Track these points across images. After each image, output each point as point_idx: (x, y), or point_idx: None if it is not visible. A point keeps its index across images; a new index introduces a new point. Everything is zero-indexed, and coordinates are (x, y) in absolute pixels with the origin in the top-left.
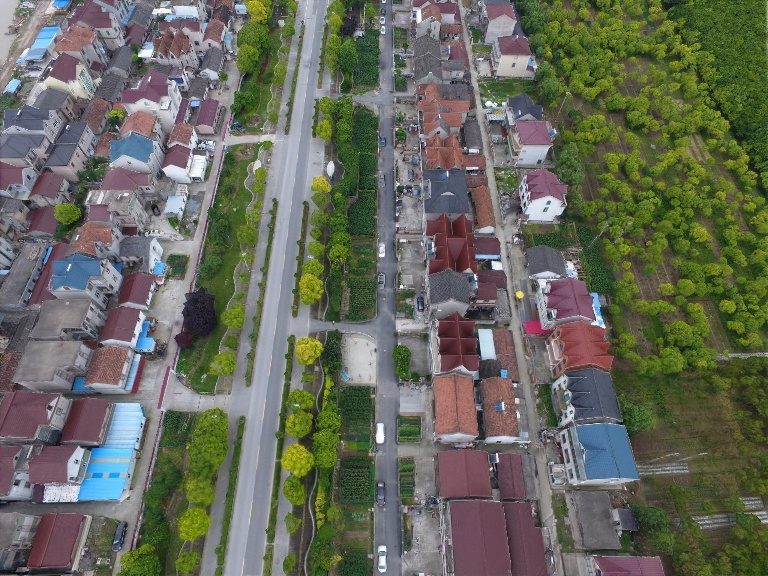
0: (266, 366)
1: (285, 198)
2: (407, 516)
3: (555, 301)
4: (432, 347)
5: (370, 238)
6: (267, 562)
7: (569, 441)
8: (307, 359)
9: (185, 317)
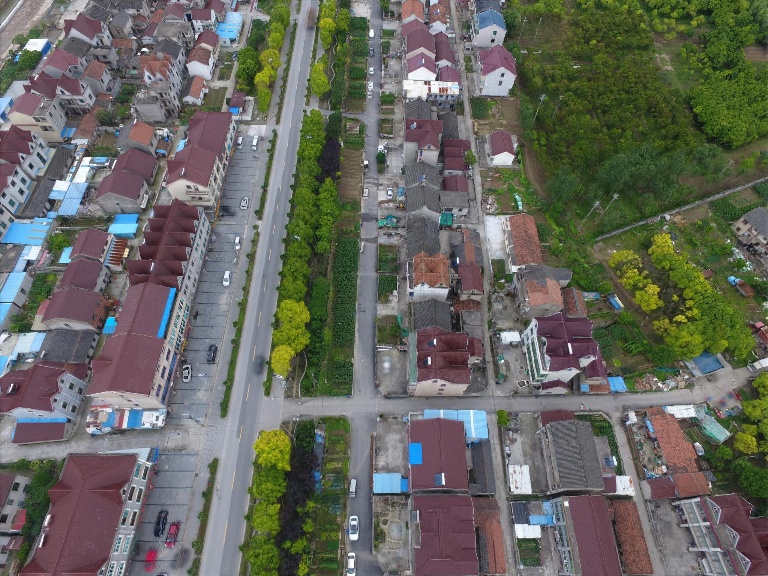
0: (307, 8)
1: None
2: (385, 59)
3: None
4: None
5: None
6: None
7: None
8: None
9: None
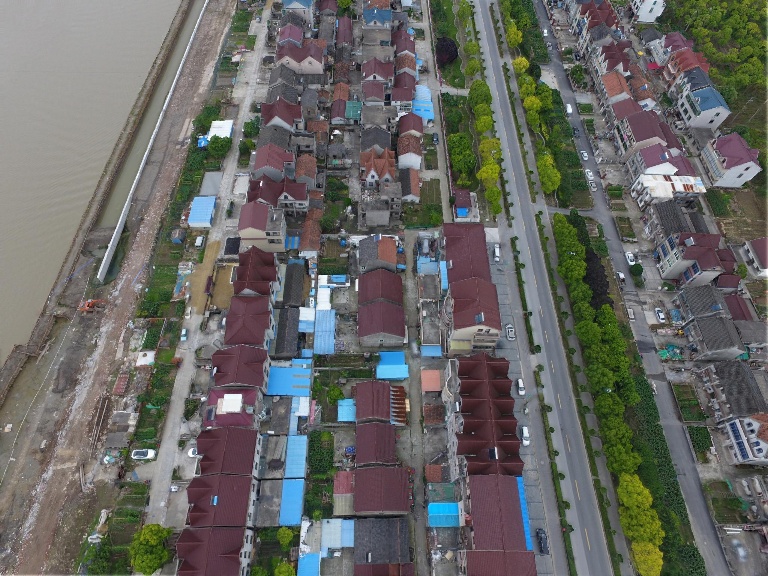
0: (492, 78)
1: (475, 4)
2: (593, 141)
3: (669, 43)
4: (596, 64)
5: (535, 27)
6: (523, 149)
7: (687, 101)
8: (522, 68)
9: (438, 51)
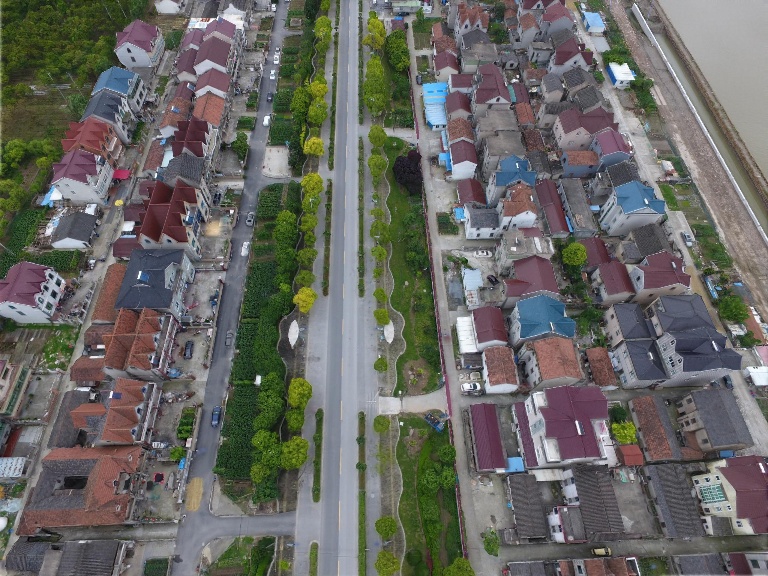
0: (350, 151)
1: (352, 302)
2: None
3: None
4: (214, 144)
5: None
6: (335, 69)
7: None
8: None
9: None
